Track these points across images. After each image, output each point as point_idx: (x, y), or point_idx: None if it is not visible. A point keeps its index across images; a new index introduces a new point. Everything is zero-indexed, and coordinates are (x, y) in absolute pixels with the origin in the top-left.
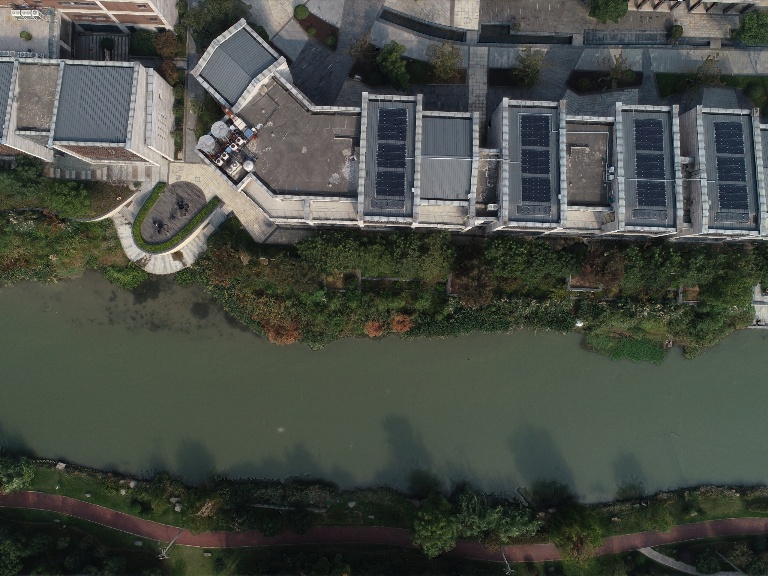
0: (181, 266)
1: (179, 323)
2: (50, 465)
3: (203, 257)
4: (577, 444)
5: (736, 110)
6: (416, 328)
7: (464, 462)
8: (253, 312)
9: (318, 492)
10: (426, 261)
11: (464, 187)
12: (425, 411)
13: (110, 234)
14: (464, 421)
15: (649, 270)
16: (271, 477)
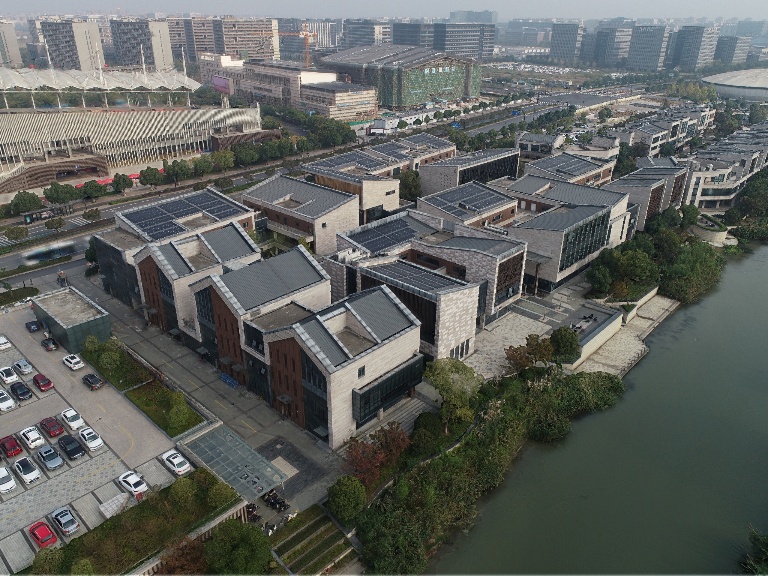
0: (735, 239)
1: None
2: None
3: None
4: None
5: None
6: None
7: None
8: None
9: None
10: None
11: None
12: None
13: None
14: None
15: None
16: None
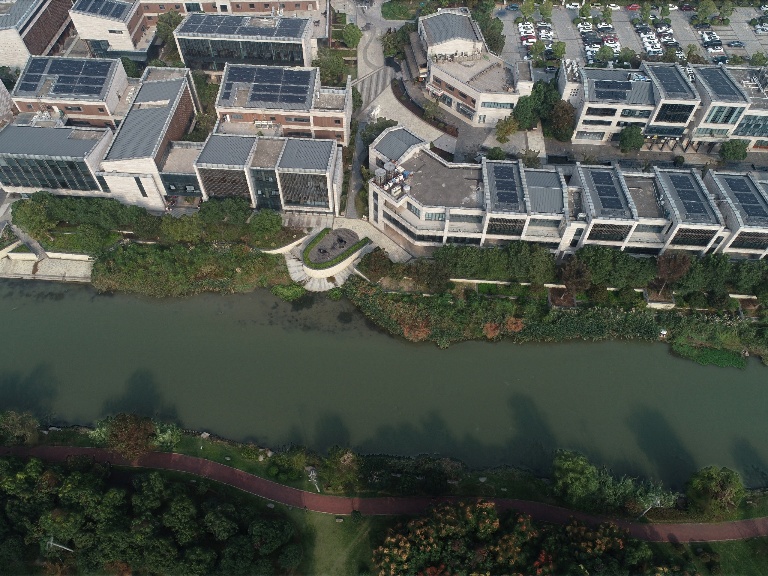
0: (333, 286)
1: (327, 326)
2: (195, 434)
3: (353, 276)
4: (690, 435)
5: (736, 173)
6: (527, 329)
7: (586, 447)
8: (391, 314)
9: (450, 463)
10: (536, 256)
11: (559, 206)
12: (542, 401)
13: (281, 263)
14: (579, 411)
15: (709, 273)
16: (402, 455)
